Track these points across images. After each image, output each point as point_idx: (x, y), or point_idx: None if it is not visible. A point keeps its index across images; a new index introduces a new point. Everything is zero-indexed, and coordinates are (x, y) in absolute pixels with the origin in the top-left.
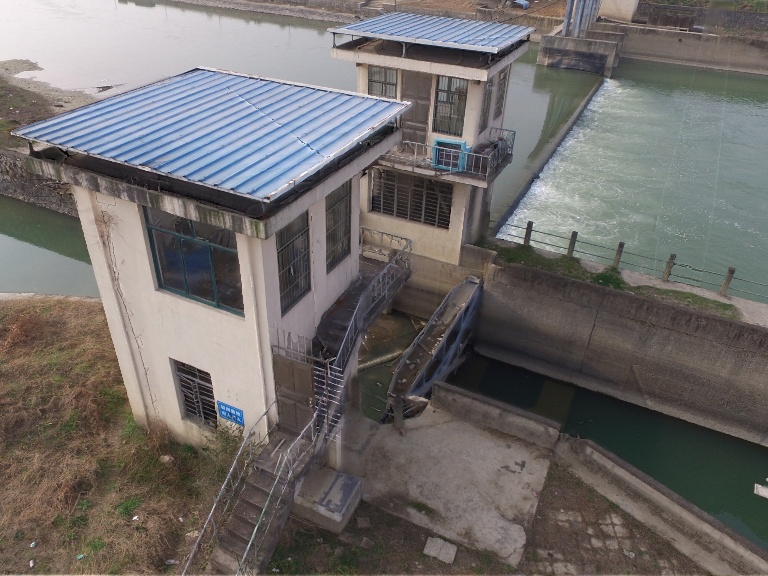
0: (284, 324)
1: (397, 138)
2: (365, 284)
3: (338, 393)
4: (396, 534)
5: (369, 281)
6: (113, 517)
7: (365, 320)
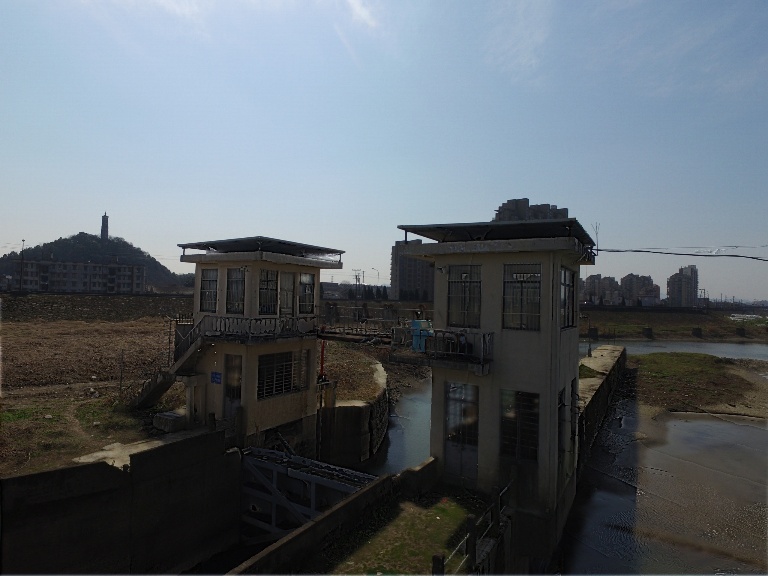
0: None
1: (258, 255)
2: None
3: None
4: (137, 437)
5: None
6: None
7: None
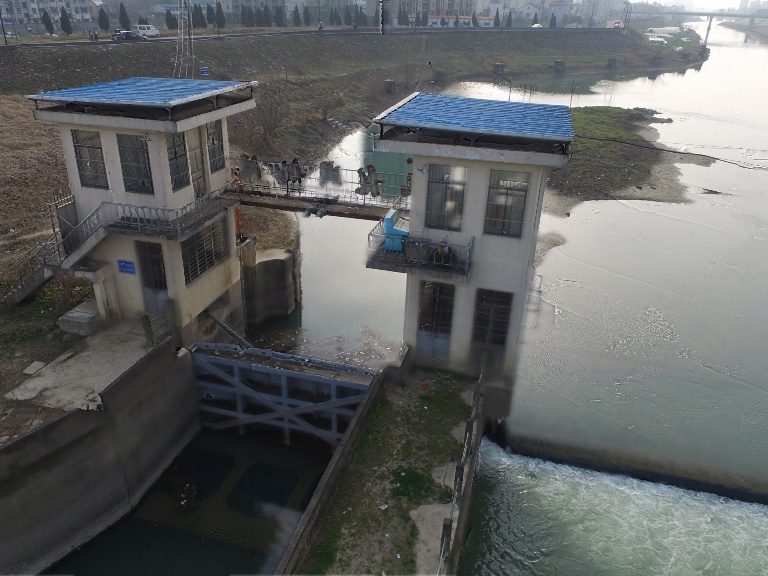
0: (85, 192)
1: (170, 127)
2: None
3: (83, 249)
4: (53, 349)
5: None
6: None
7: (116, 227)
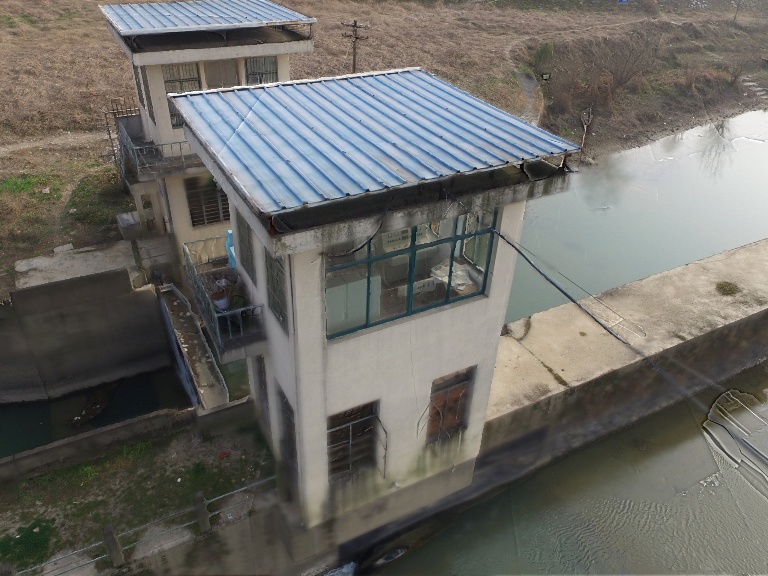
0: None
1: None
2: (155, 158)
3: None
4: (92, 239)
5: (156, 160)
6: None
7: None
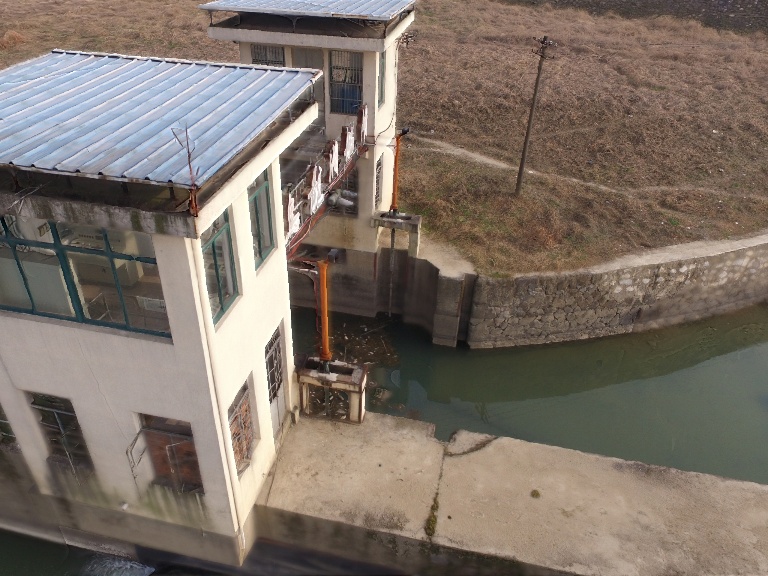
0: None
1: None
2: None
3: None
4: None
5: None
6: None
7: None
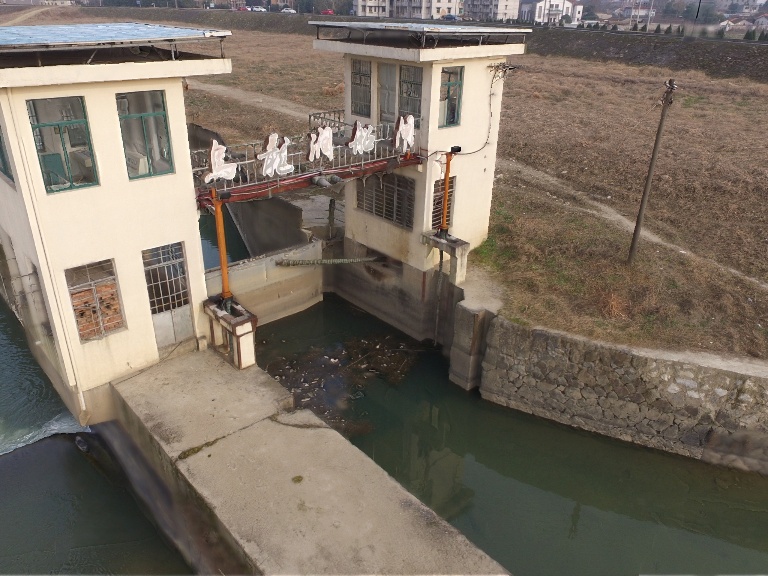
0: None
1: None
2: None
3: None
4: None
5: (341, 136)
6: (492, 217)
7: None
